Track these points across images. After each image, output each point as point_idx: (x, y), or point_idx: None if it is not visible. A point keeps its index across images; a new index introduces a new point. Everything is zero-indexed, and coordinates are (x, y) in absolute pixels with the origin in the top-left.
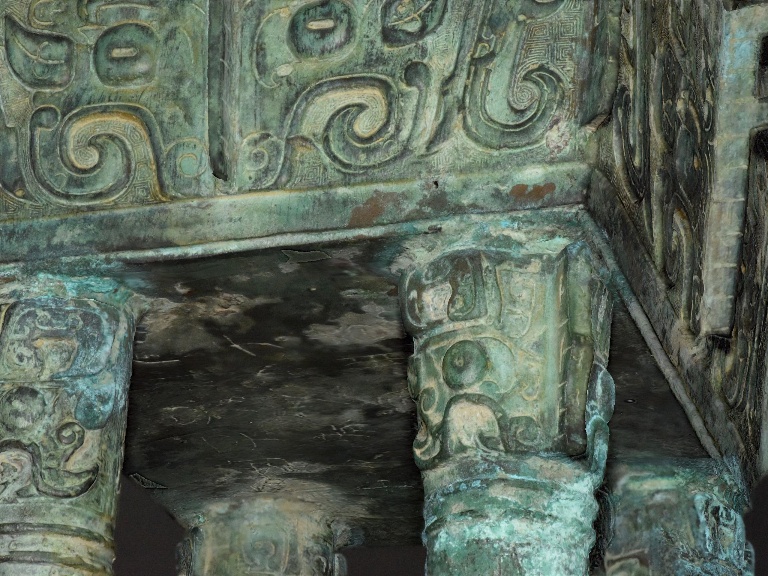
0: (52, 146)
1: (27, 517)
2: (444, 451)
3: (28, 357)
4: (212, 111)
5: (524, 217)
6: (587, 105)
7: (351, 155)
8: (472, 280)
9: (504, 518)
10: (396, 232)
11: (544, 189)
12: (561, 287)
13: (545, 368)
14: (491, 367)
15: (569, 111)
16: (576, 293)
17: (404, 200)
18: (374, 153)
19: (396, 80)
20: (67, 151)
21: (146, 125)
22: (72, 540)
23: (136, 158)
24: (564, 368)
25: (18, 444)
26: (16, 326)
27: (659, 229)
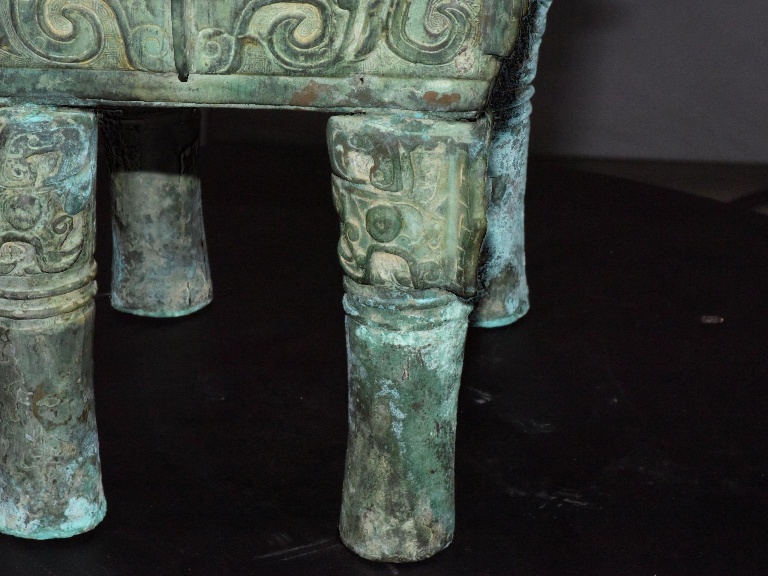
0: (31, 15)
1: (34, 286)
2: (367, 281)
3: (24, 172)
4: (176, 30)
5: (434, 113)
6: (490, 41)
7: (292, 56)
8: (391, 163)
9: (412, 331)
10: (328, 109)
11: (451, 98)
12: (462, 173)
13: (446, 226)
14: (405, 226)
15: (475, 39)
16: (475, 185)
17: (335, 91)
18: (311, 57)
19: (330, 2)
20: (44, 19)
21: (113, 10)
22: (69, 293)
23: (105, 31)
24: (463, 241)
25: (23, 239)
26: (11, 147)
27: (526, 1)
